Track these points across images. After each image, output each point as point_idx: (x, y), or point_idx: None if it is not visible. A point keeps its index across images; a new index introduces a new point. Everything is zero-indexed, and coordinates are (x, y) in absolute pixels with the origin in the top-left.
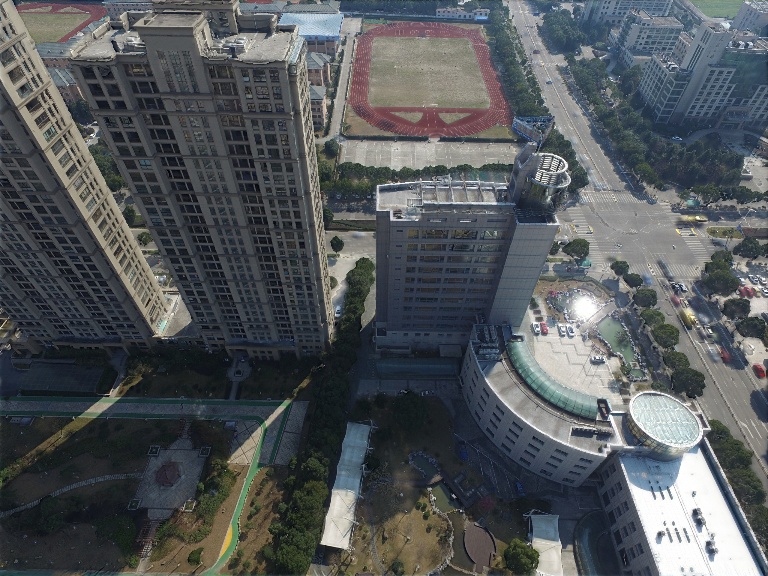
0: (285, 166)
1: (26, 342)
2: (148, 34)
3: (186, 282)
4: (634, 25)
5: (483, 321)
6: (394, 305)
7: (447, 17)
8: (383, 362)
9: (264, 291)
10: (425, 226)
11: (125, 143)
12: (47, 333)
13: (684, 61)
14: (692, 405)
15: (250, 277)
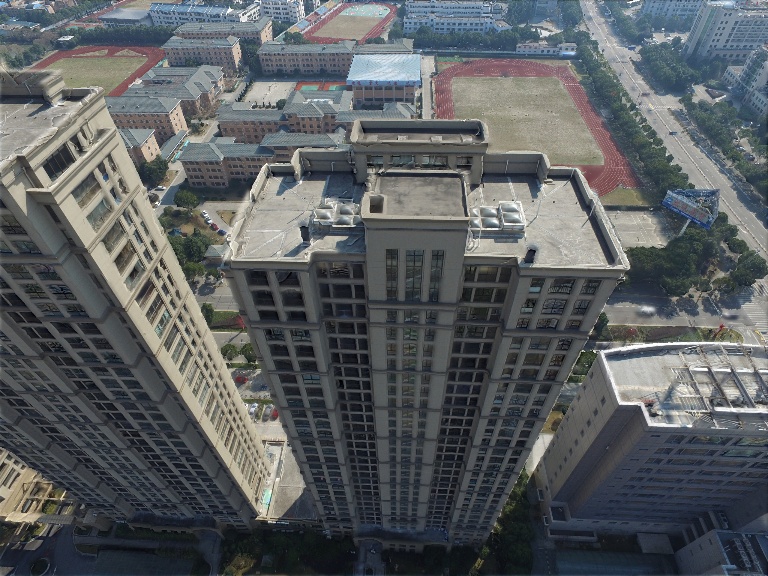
0: (538, 387)
1: (94, 522)
2: (380, 227)
3: (322, 483)
4: (767, 63)
5: (728, 527)
6: (596, 498)
7: (528, 53)
8: (564, 560)
9: (428, 493)
10: (699, 433)
11: (288, 357)
12: (121, 512)
13: None
14: None
15: (415, 481)
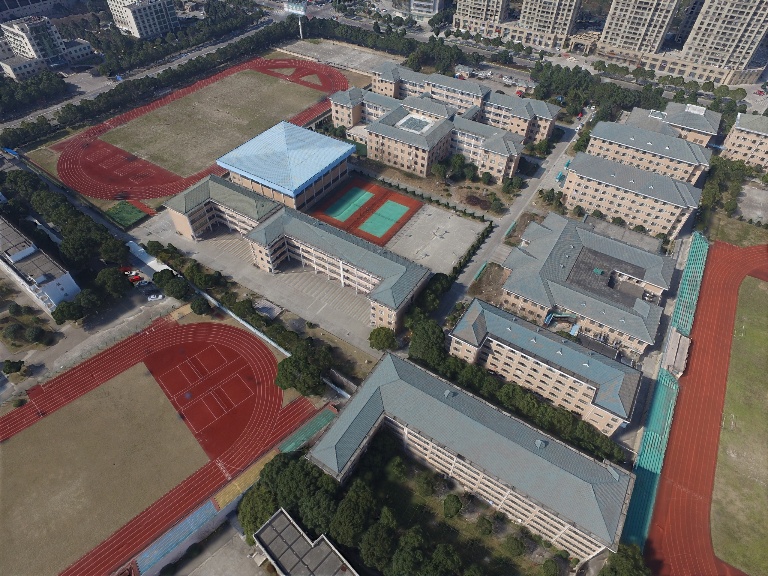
0: None
1: None
2: None
3: None
4: None
5: None
6: None
7: None
8: None
9: None
10: None
11: None
12: None
13: None
14: None
15: None
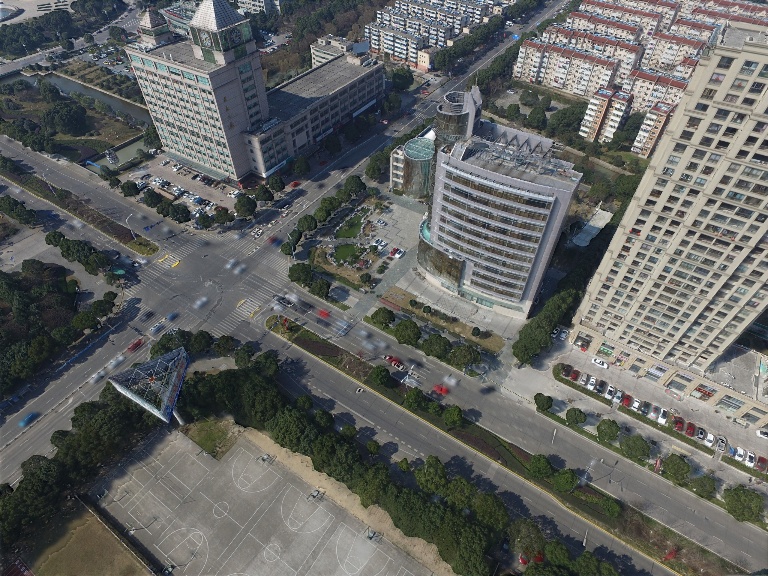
0: None
1: None
2: None
3: None
4: None
5: None
6: None
7: None
8: None
9: None
10: None
11: None
12: None
13: None
14: (395, 153)
15: None
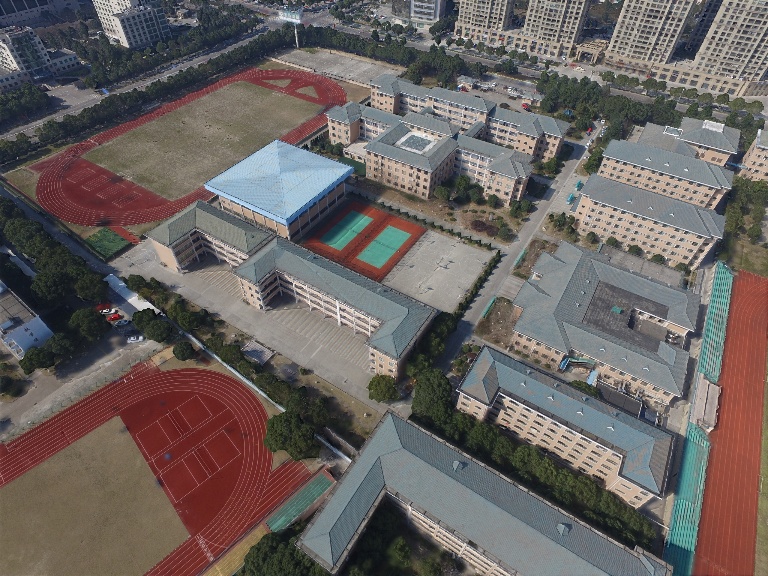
0: None
1: None
2: None
3: None
4: None
5: None
6: None
7: None
8: None
9: None
10: None
11: None
12: None
13: (132, 3)
14: None
15: None
